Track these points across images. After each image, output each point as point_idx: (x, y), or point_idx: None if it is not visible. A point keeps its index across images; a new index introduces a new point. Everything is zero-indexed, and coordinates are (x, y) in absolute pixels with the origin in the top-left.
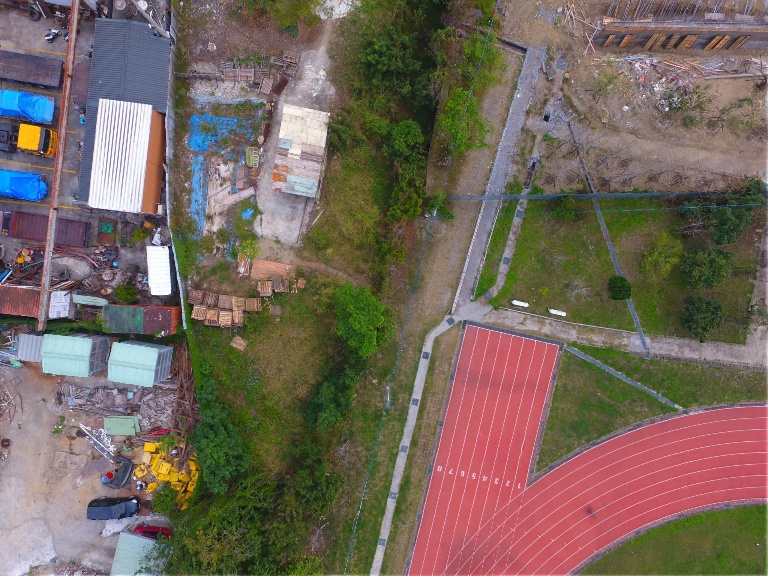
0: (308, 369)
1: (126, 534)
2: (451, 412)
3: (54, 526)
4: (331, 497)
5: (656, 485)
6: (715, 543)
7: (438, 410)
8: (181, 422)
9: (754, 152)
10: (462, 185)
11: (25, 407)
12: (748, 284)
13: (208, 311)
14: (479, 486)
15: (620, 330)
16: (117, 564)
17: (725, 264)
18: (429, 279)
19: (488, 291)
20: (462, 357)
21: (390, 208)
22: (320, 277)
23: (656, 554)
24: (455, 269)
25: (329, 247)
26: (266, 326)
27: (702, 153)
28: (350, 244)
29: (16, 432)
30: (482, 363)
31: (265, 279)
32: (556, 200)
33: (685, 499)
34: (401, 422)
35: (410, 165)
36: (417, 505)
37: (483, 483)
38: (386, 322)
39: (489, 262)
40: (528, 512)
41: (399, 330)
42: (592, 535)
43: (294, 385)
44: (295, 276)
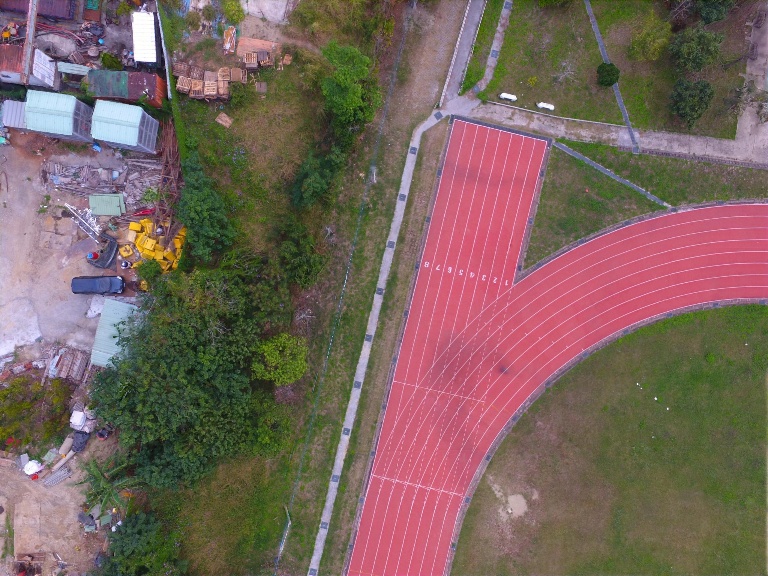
0: (294, 150)
1: (110, 300)
2: (438, 208)
3: (39, 306)
4: (316, 263)
5: (644, 283)
6: (703, 343)
7: (425, 206)
8: (166, 200)
9: None
10: None
11: (10, 186)
12: (738, 78)
13: (193, 81)
14: (466, 283)
15: (609, 124)
16: (101, 330)
17: (714, 41)
18: (417, 72)
19: (476, 85)
20: (450, 152)
21: None
22: (306, 52)
23: (644, 353)
24: (443, 62)
25: (315, 22)
26: (252, 103)
27: None
28: (337, 24)
29: (1, 211)
30: (470, 158)
31: (251, 52)
32: None
33: (673, 298)
34: (388, 217)
35: None
36: (404, 301)
37: (470, 280)
38: (372, 93)
39: (477, 55)
40: (515, 310)
41: (386, 124)
42: (580, 333)
43: (280, 163)
44: (281, 53)
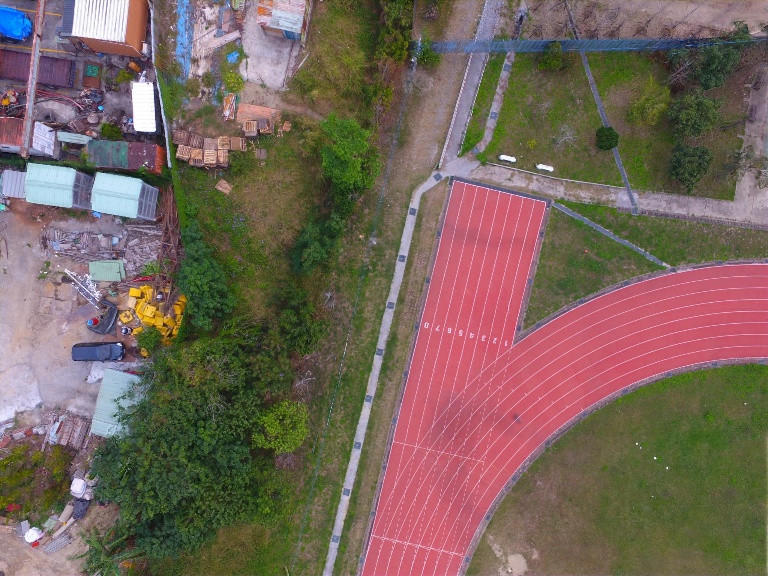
0: (294, 215)
1: (110, 370)
2: (438, 269)
3: (39, 372)
4: (315, 333)
5: (643, 343)
6: (702, 402)
7: (425, 267)
8: (166, 266)
9: (743, 5)
10: (449, 38)
11: (10, 252)
12: (736, 140)
13: (193, 150)
14: (466, 343)
15: (608, 185)
16: (101, 400)
17: (712, 107)
18: (416, 134)
19: (475, 146)
20: (449, 213)
21: (376, 52)
22: (305, 119)
23: (643, 413)
24: (442, 124)
25: (315, 89)
26: (251, 170)
27: (691, 6)
28: (336, 90)
29: (1, 277)
30: (469, 219)
31: (250, 120)
32: (543, 51)
33: (673, 358)
34: (388, 278)
35: (396, 4)
36: (404, 362)
37: (470, 340)
38: (371, 161)
39: (476, 117)
40: (515, 370)
41: (386, 185)
42: (579, 393)
43: (279, 230)
44: (281, 120)
